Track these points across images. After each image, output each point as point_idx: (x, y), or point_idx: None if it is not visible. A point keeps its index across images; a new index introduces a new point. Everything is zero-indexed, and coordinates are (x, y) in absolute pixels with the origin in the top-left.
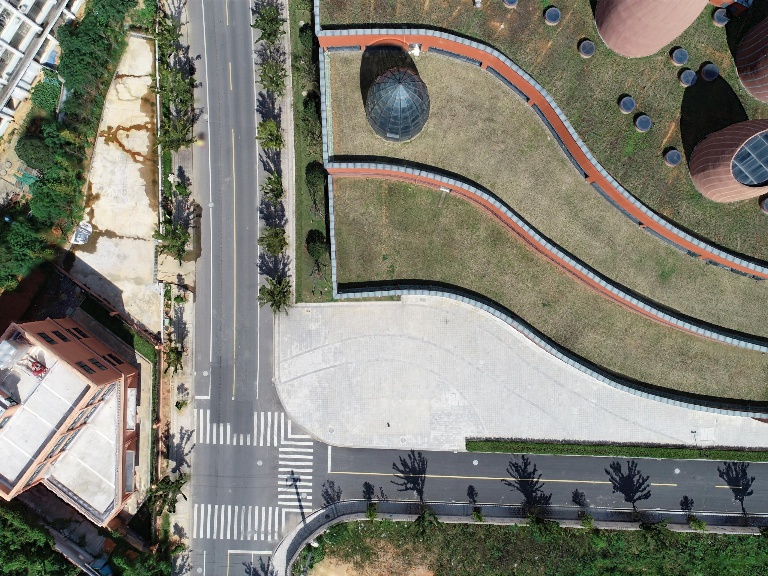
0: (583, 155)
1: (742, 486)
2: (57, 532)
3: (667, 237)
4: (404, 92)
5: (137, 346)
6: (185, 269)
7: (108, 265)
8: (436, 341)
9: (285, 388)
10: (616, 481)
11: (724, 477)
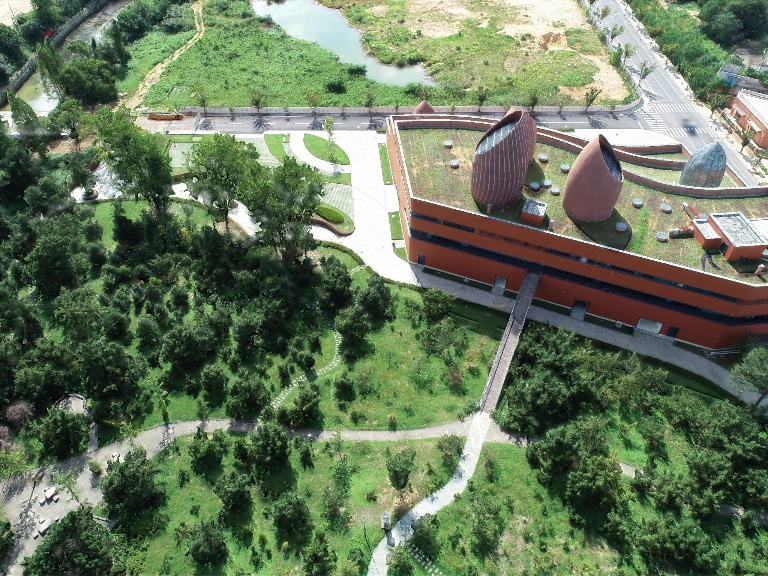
0: None
1: None
2: (760, 89)
3: None
4: None
5: None
6: (763, 180)
7: None
8: None
9: None
10: None
11: None
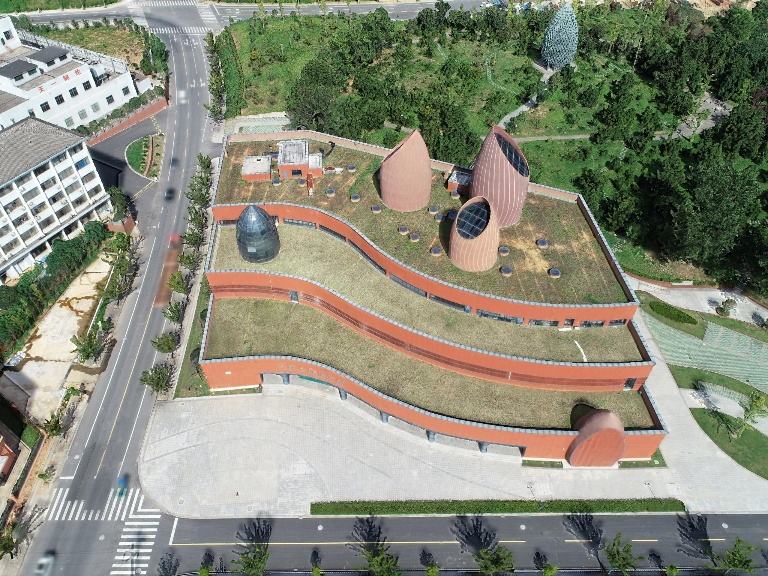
0: (376, 252)
1: (592, 539)
2: None
3: (444, 297)
4: (254, 211)
5: (24, 437)
6: (89, 380)
7: (27, 379)
8: (289, 421)
9: (146, 466)
10: (463, 540)
11: (571, 531)
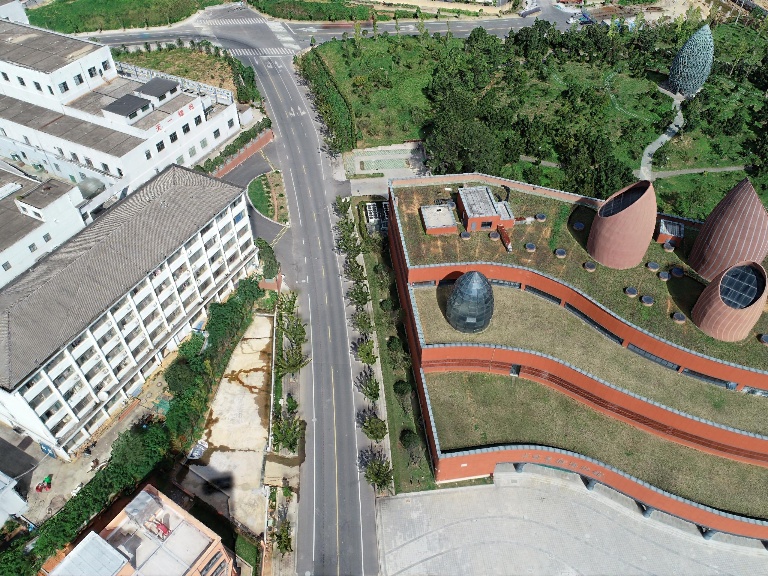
0: (614, 320)
1: None
2: None
3: (703, 372)
4: (479, 278)
5: (238, 550)
6: (290, 473)
7: (218, 475)
8: (537, 519)
9: None
10: None
11: None
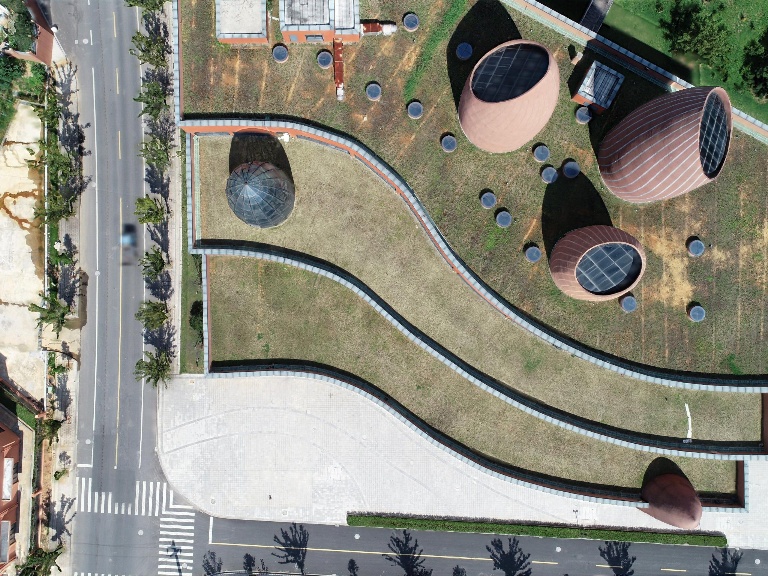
0: None
1: (623, 566)
2: None
3: None
4: (251, 191)
5: (20, 413)
6: (70, 337)
7: None
8: (319, 415)
9: (168, 458)
10: (497, 558)
11: (605, 556)
